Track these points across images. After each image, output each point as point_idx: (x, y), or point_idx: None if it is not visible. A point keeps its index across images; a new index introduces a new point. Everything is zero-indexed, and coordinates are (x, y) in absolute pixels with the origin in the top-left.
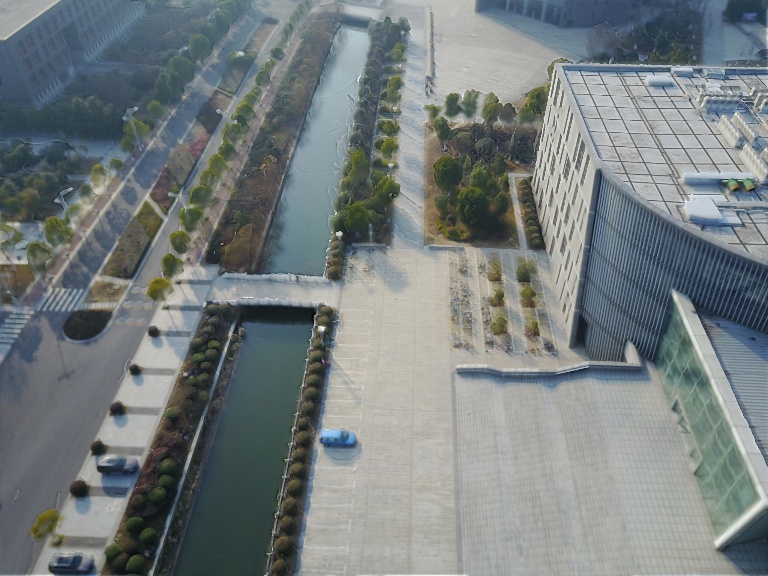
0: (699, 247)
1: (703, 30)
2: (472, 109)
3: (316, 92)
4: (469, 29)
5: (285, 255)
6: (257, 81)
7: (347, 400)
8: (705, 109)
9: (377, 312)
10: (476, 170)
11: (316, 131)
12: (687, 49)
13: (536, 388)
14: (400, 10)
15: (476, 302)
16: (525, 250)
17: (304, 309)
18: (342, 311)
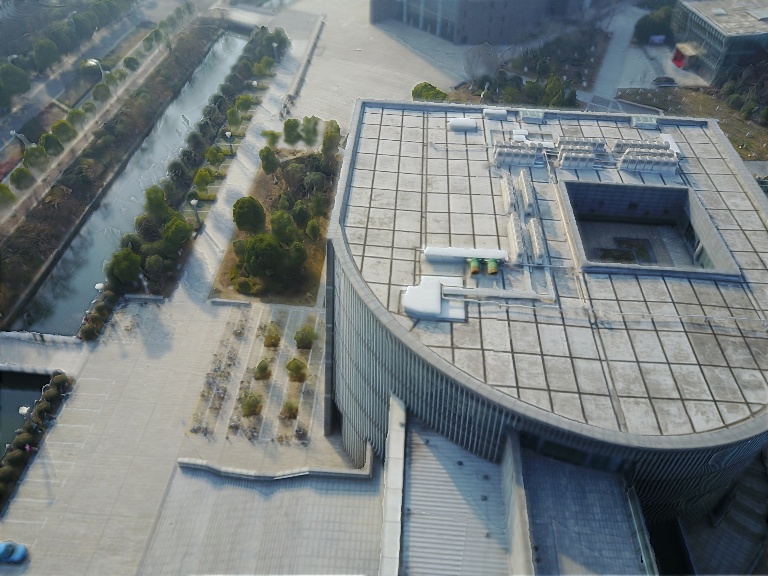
0: (402, 349)
1: (605, 52)
2: (313, 137)
3: (172, 107)
4: (357, 42)
5: (71, 300)
6: (94, 95)
7: (38, 499)
8: (496, 163)
9: (120, 383)
10: (277, 214)
11: (160, 152)
12: (578, 74)
13: (249, 495)
14: (292, 18)
15: (239, 373)
16: (320, 308)
17: (40, 376)
18: (80, 380)
